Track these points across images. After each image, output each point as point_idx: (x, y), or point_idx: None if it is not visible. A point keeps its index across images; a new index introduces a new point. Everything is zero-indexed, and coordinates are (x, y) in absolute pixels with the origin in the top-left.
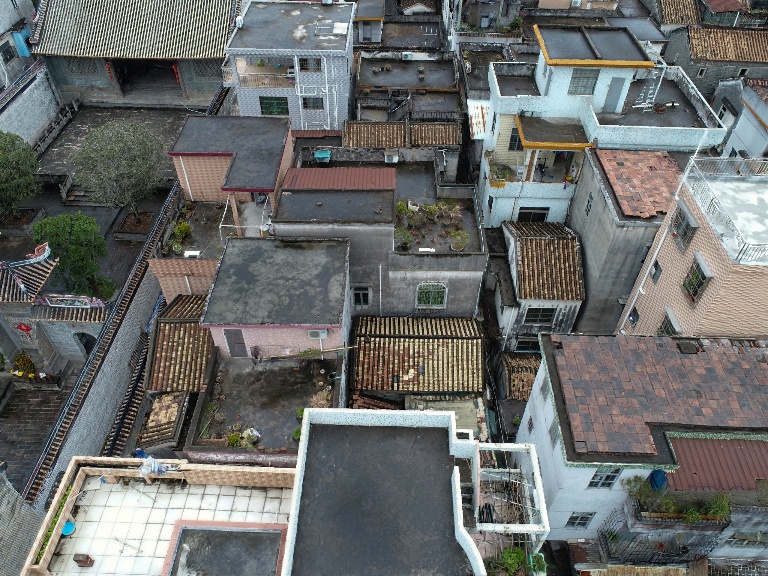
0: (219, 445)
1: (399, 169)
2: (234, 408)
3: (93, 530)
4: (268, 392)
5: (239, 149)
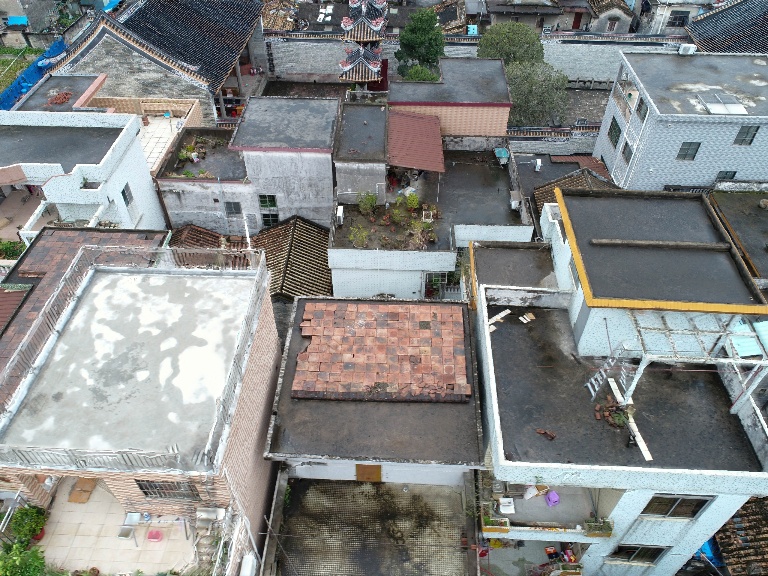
0: (189, 144)
1: (504, 213)
2: (221, 151)
3: (164, 123)
4: (230, 163)
5: (449, 84)
